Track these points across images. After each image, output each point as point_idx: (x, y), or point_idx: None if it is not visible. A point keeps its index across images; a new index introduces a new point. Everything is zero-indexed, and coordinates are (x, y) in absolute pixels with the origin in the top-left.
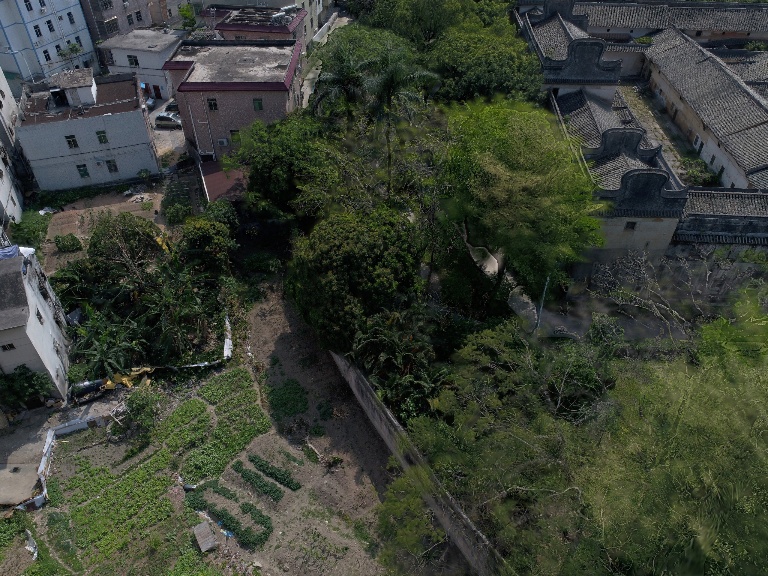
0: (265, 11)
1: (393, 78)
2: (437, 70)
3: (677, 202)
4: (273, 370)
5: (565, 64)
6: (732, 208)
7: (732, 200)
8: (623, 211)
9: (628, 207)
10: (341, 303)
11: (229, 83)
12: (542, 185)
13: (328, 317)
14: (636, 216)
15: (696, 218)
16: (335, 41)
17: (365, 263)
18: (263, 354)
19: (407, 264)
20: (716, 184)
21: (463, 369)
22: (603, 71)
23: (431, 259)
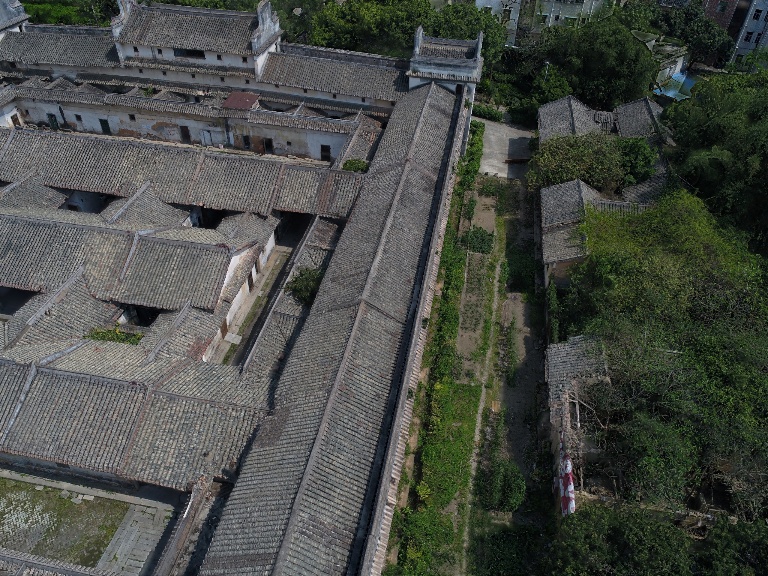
0: None
1: None
2: None
3: None
4: None
5: None
6: None
7: None
8: None
9: None
10: None
11: None
12: None
13: None
14: None
15: None
16: None
17: None
18: None
19: None
20: None
21: None
22: None
23: None
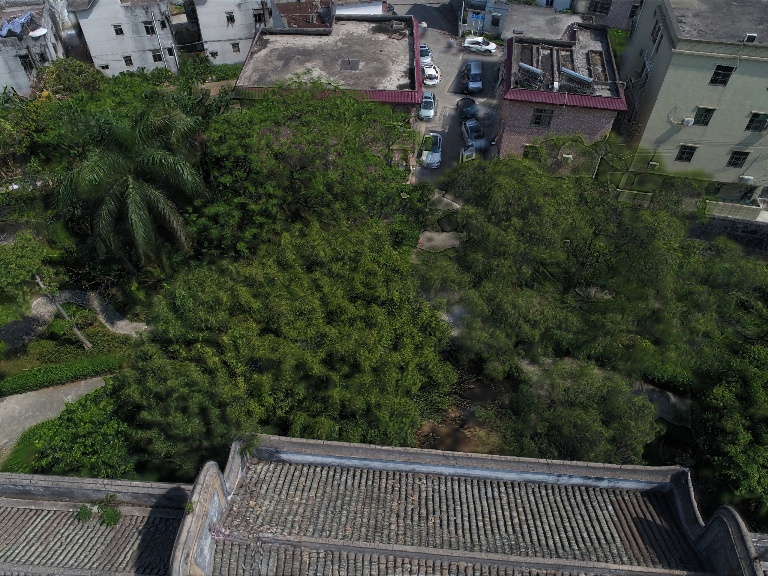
0: None
1: None
2: None
3: None
4: None
5: None
6: None
7: None
8: None
9: None
10: None
11: None
12: None
13: None
14: None
15: None
16: None
17: None
18: None
19: None
20: None
21: None
22: None
23: None
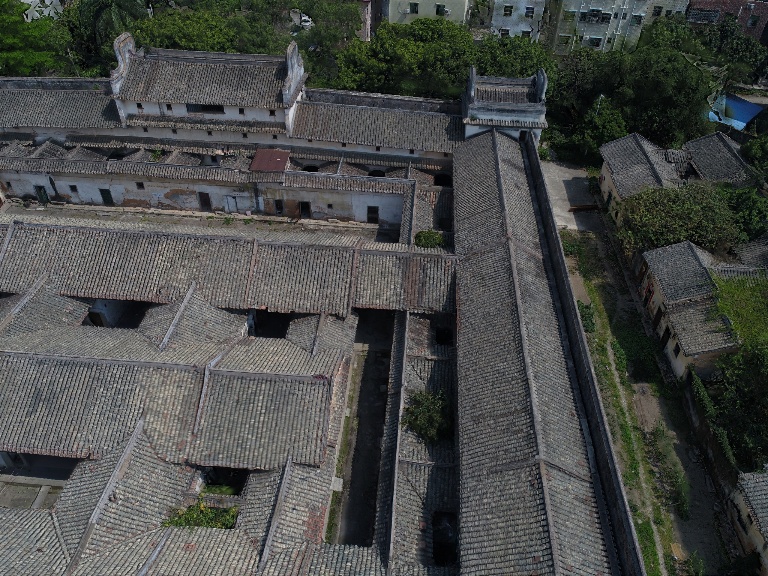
0: None
1: None
2: None
3: None
4: None
5: None
6: None
7: None
8: None
9: None
10: None
11: None
12: None
13: None
14: None
15: None
16: None
17: None
18: None
19: None
20: None
21: None
22: None
23: None
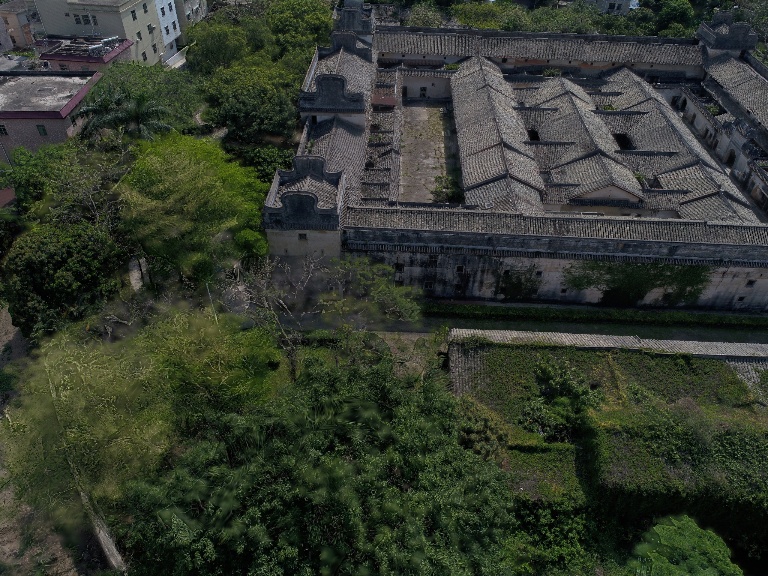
0: (94, 41)
1: (136, 111)
2: (209, 100)
3: (331, 218)
4: (3, 356)
5: (316, 95)
6: (399, 222)
7: (401, 215)
8: (291, 225)
9: (294, 221)
10: (26, 300)
11: (12, 112)
12: (176, 206)
13: (16, 311)
14: (301, 229)
15: (358, 230)
16: (110, 76)
17: (46, 268)
18: (0, 343)
19: (92, 268)
20: (458, 198)
21: (132, 353)
22: (350, 102)
23: (139, 264)
